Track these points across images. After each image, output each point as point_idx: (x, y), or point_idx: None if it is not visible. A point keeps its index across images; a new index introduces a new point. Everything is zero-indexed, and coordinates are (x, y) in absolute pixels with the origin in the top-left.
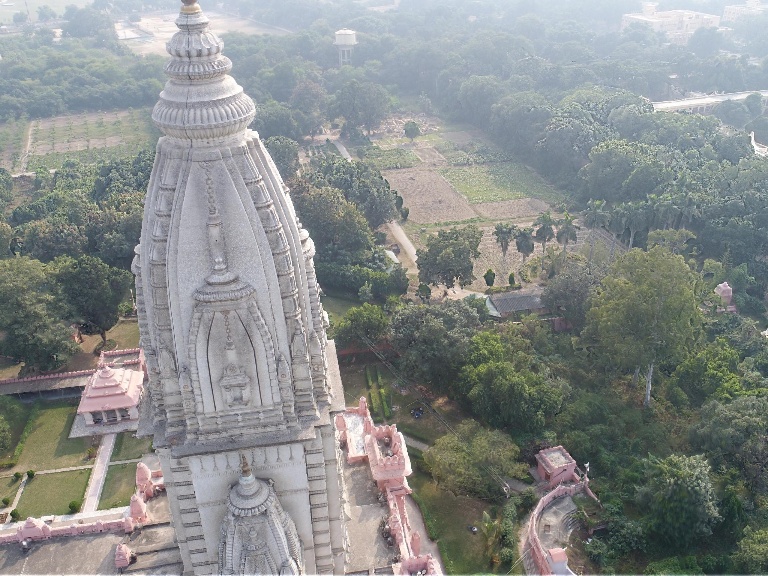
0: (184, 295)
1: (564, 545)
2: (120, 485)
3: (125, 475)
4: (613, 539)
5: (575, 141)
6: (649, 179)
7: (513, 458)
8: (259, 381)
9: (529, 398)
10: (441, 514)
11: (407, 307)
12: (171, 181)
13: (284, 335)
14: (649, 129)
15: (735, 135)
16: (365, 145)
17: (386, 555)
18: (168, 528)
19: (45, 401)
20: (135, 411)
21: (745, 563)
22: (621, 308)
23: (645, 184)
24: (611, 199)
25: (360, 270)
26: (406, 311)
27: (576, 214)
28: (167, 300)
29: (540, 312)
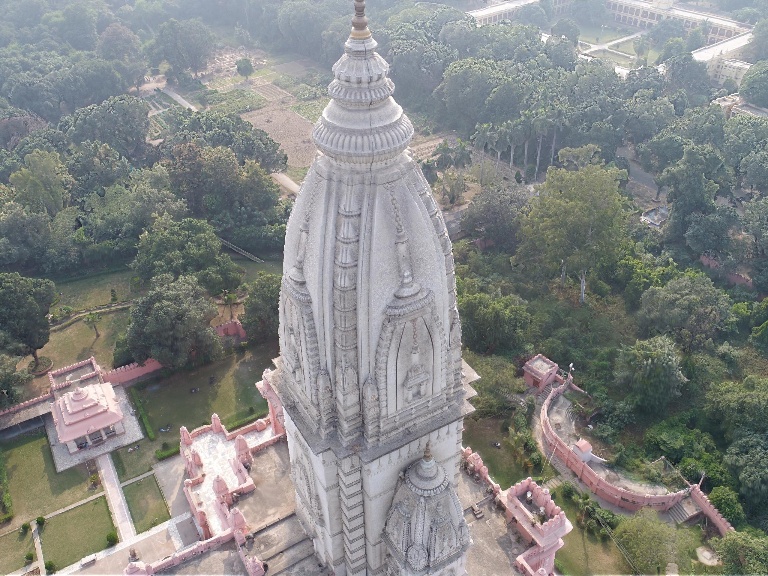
0: (376, 313)
1: (577, 436)
2: (146, 503)
3: (146, 492)
4: (610, 420)
5: (421, 63)
6: (512, 95)
7: (513, 375)
8: (433, 374)
9: (507, 320)
10: (464, 440)
11: None
12: (355, 207)
13: (447, 327)
14: (481, 43)
15: (561, 42)
16: (199, 90)
17: (479, 489)
18: (278, 528)
19: (4, 441)
20: (121, 425)
21: (717, 411)
22: (569, 225)
23: (508, 100)
24: (475, 117)
25: (282, 228)
26: None
27: (441, 135)
28: (355, 321)
29: (457, 236)
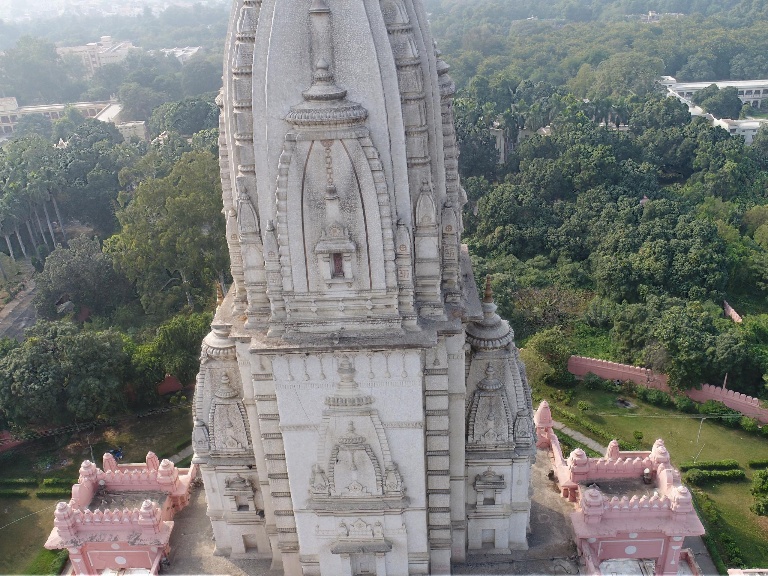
0: None
1: None
2: None
3: None
4: None
5: None
6: None
7: None
8: None
9: None
10: None
11: (2, 364)
12: None
13: None
14: None
15: None
16: None
17: None
18: None
19: None
20: None
21: None
22: (206, 214)
23: None
24: None
25: None
26: (17, 361)
27: None
28: None
29: None
